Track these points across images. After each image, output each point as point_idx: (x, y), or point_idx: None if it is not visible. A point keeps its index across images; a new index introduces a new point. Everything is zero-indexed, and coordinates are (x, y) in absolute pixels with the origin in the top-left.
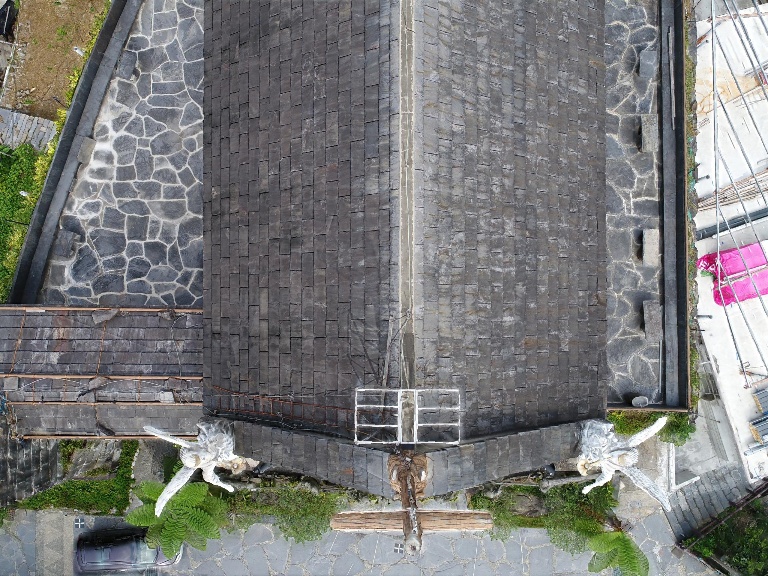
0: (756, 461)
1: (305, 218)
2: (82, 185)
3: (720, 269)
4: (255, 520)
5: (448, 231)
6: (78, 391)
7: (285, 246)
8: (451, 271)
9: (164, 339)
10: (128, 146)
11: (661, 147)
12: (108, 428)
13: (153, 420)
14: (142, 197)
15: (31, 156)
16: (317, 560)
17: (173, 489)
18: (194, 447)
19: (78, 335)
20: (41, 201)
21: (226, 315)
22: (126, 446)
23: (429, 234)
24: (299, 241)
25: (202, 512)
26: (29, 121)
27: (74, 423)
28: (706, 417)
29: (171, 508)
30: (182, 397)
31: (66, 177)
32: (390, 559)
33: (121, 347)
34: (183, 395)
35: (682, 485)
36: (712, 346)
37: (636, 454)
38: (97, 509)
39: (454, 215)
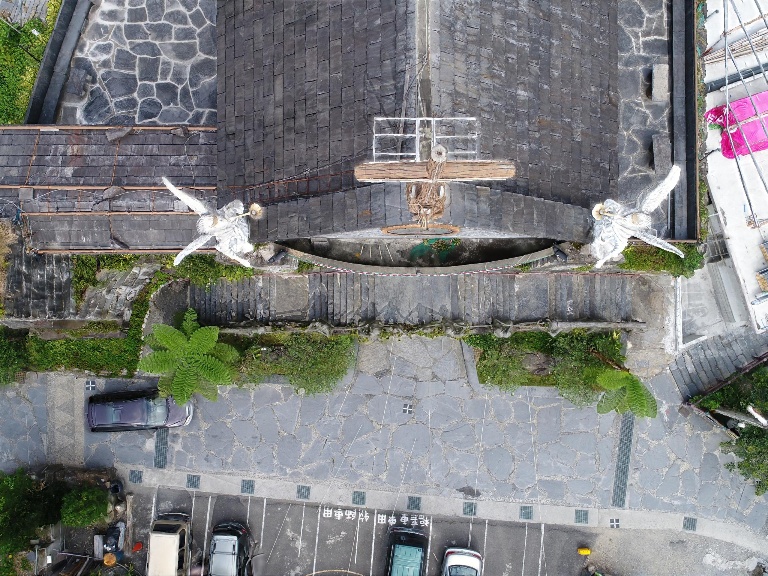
0: (763, 312)
1: None
2: (93, 27)
3: (728, 109)
4: (265, 375)
5: None
6: (93, 201)
7: (300, 27)
8: (466, 29)
9: (177, 154)
10: None
11: None
12: (122, 242)
13: (167, 232)
14: (153, 39)
15: (40, 28)
16: (326, 421)
17: (191, 247)
18: (211, 213)
19: (92, 151)
20: (53, 38)
21: (240, 113)
22: (136, 308)
23: None
24: (314, 18)
25: (213, 359)
26: None
27: (88, 236)
28: (713, 282)
29: (182, 357)
30: None
31: (78, 17)
32: (399, 419)
33: (135, 162)
34: None
35: (689, 344)
36: (720, 199)
37: (649, 219)
38: (108, 370)
39: None
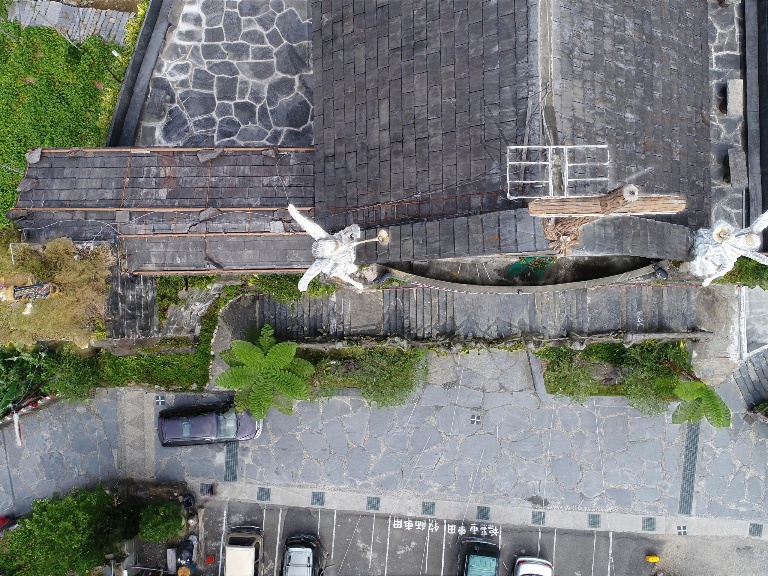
0: None
1: (430, 20)
2: (171, 47)
3: None
4: (337, 388)
5: (580, 16)
6: (189, 223)
7: (408, 52)
8: (583, 56)
9: (270, 175)
10: (216, 8)
11: (742, 1)
12: (217, 262)
13: (261, 253)
14: (231, 58)
15: (101, 46)
16: (395, 433)
17: (314, 272)
18: (329, 237)
19: (184, 173)
20: (134, 59)
21: (341, 136)
22: (205, 323)
23: (564, 14)
24: (423, 44)
25: (290, 374)
26: (97, 14)
27: (183, 257)
28: None
29: (258, 372)
30: (292, 227)
31: (156, 38)
32: (467, 430)
33: (228, 183)
34: (293, 225)
35: (753, 352)
36: None
37: None
38: (178, 385)
39: (584, 2)
